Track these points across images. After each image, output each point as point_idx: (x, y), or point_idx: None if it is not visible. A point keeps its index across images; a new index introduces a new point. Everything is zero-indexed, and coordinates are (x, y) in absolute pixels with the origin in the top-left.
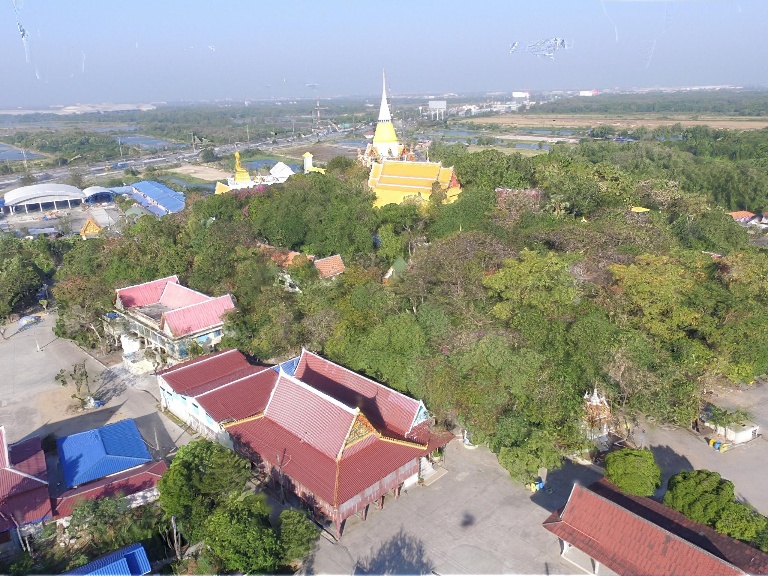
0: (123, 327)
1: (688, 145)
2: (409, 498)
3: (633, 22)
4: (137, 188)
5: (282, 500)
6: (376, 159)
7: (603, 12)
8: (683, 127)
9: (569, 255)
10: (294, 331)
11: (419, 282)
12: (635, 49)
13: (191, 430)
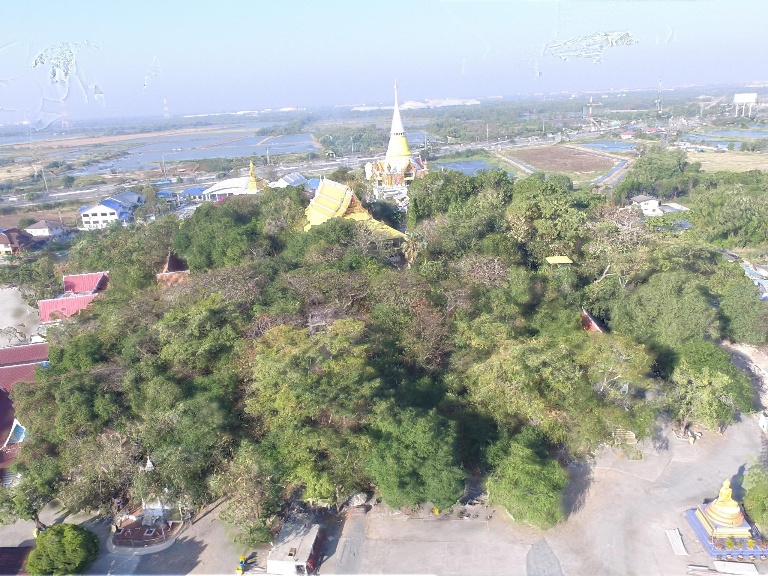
0: None
1: None
2: None
3: (500, 24)
4: None
5: None
6: None
7: (450, 16)
8: None
9: (281, 305)
10: (65, 334)
11: (134, 309)
12: (513, 57)
13: None
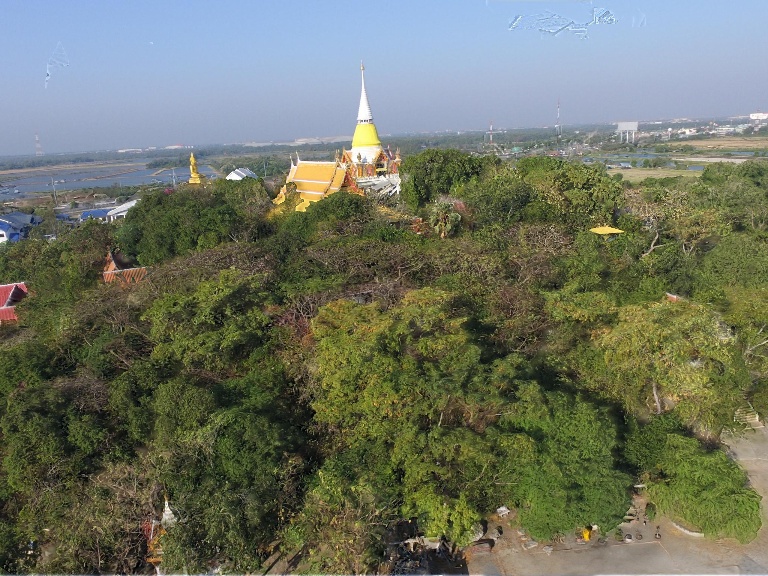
0: None
1: None
2: None
3: None
4: None
5: None
6: (349, 166)
7: None
8: None
9: (318, 282)
10: None
11: (97, 304)
12: None
13: None
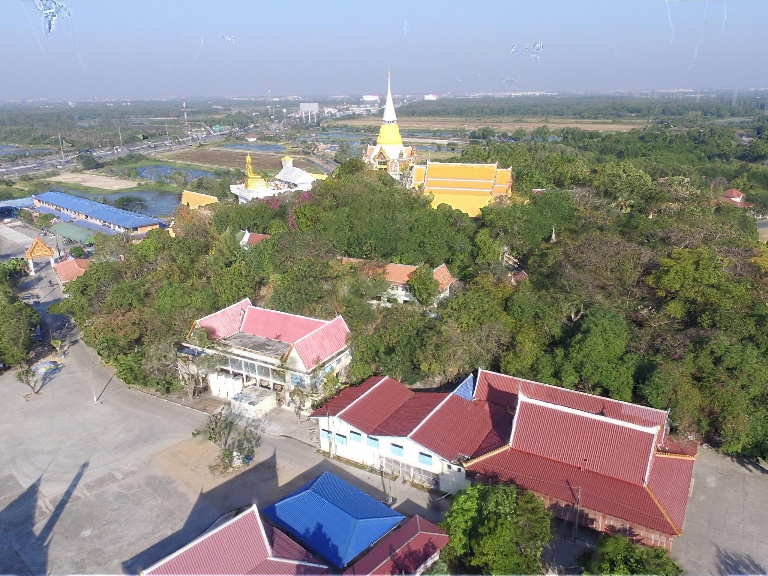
0: (207, 364)
1: (577, 145)
2: (688, 513)
3: (685, 28)
4: (45, 200)
5: (575, 538)
6: (385, 162)
7: (667, 17)
8: (549, 129)
9: None
10: (467, 350)
11: (589, 287)
12: (682, 54)
13: (387, 475)
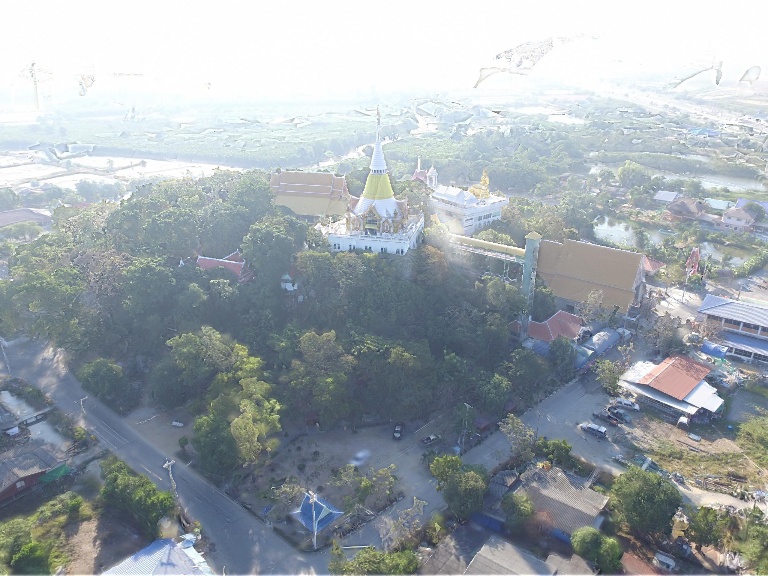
0: None
1: None
2: None
3: (129, 71)
4: None
5: None
6: None
7: None
8: None
9: None
10: None
11: None
12: None
13: None
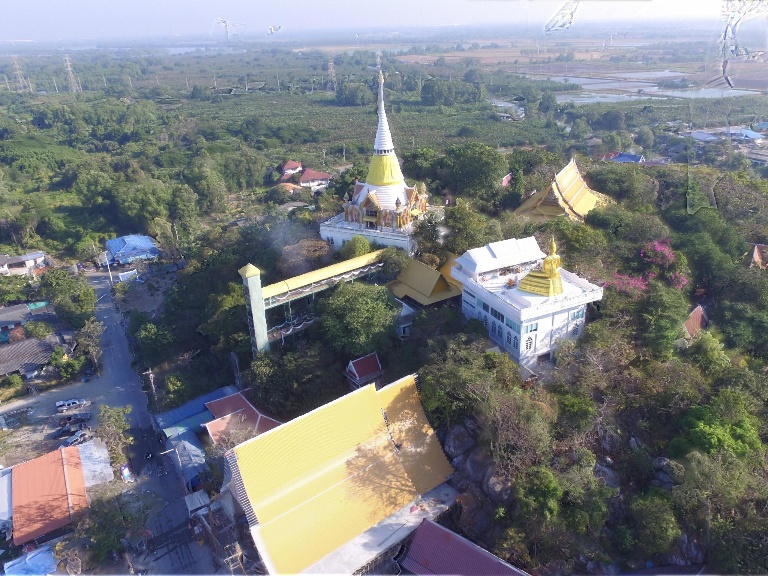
0: None
1: None
2: None
3: None
4: None
5: None
6: (414, 205)
7: None
8: None
9: None
10: None
11: None
12: None
13: None
